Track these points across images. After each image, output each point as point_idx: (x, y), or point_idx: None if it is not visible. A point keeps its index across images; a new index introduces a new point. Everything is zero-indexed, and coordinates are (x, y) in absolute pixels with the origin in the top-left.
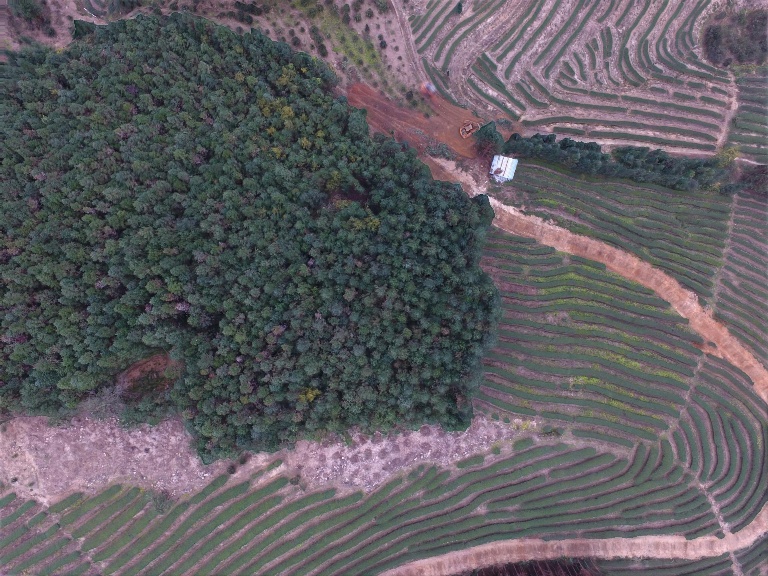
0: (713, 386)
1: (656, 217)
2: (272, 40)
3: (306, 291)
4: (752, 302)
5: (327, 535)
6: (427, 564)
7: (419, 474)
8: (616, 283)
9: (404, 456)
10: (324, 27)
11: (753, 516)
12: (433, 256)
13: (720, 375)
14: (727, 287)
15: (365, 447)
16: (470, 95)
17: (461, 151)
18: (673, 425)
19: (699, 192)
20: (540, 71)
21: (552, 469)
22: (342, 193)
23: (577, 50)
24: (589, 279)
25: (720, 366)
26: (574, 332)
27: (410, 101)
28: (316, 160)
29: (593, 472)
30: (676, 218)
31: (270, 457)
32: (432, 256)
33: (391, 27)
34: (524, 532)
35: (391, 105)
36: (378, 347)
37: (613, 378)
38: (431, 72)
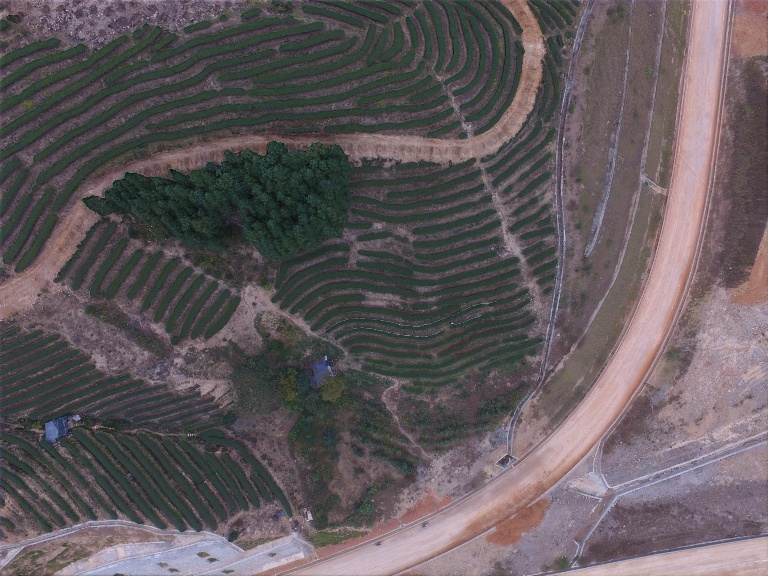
0: None
1: None
2: None
3: None
4: None
5: (56, 94)
6: (175, 159)
7: (147, 37)
8: None
9: (130, 16)
10: None
11: (495, 117)
12: None
13: None
14: None
15: (91, 4)
16: None
17: None
18: (408, 15)
19: None
20: None
21: None
22: None
23: None
24: None
25: None
26: None
27: None
28: None
29: None
30: None
31: None
32: None
33: None
34: (262, 117)
35: None
36: None
37: None
38: None
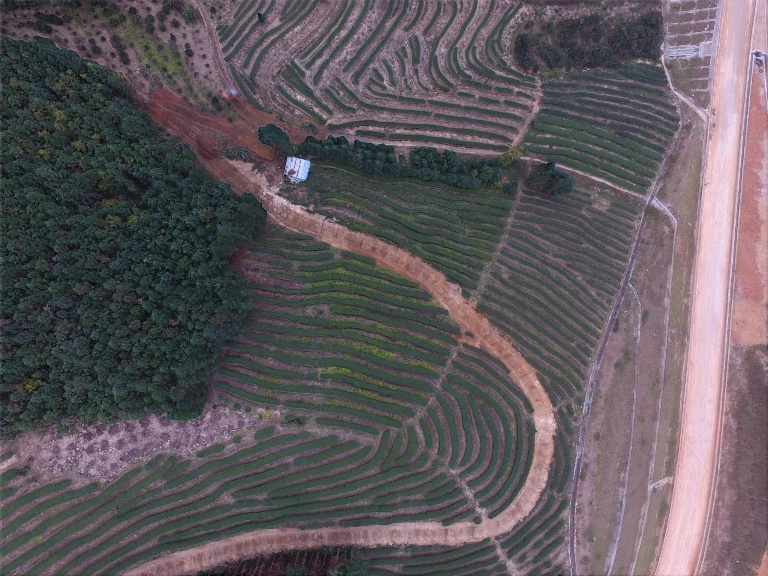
0: (467, 374)
1: (436, 214)
2: (71, 48)
3: (39, 285)
4: (520, 294)
5: (67, 527)
6: (188, 556)
7: (159, 464)
8: (381, 277)
9: (142, 446)
10: (127, 36)
11: (509, 501)
12: (175, 251)
13: (475, 364)
14: (497, 280)
15: (102, 438)
16: (278, 100)
17: (263, 154)
18: (421, 412)
19: (484, 190)
20: (350, 77)
21: (297, 457)
22: (123, 194)
23: (386, 57)
24: (356, 273)
25: (476, 355)
26: (329, 324)
27: (216, 106)
28: (83, 161)
29: (338, 460)
30: (457, 215)
31: (2, 449)
32: (174, 251)
33: (199, 36)
34: (277, 521)
35: (193, 110)
36: (99, 338)
37: (361, 367)
38: (239, 79)
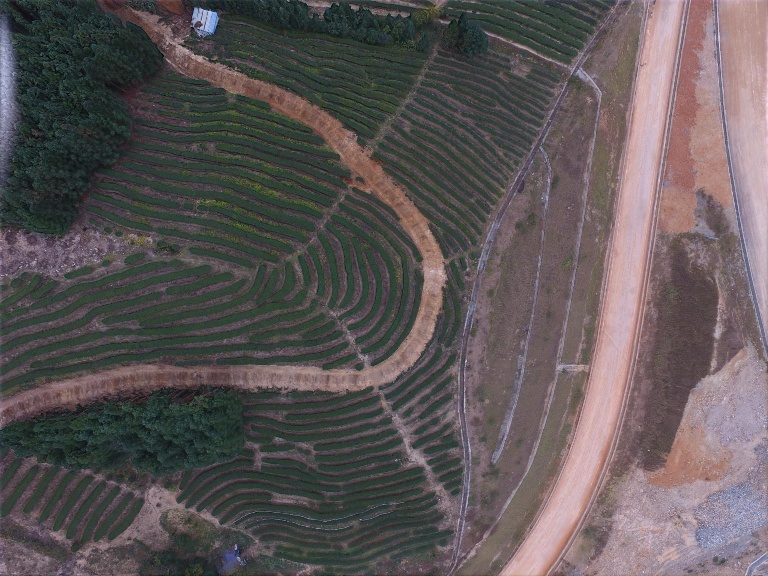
0: (354, 218)
1: (342, 68)
2: None
3: None
4: (421, 148)
5: None
6: (65, 388)
7: (26, 283)
8: (274, 120)
9: (9, 264)
10: None
11: (392, 349)
12: (47, 68)
13: (364, 209)
14: (398, 133)
15: None
16: None
17: (173, 9)
18: (302, 251)
19: (397, 49)
20: None
21: (170, 287)
22: (15, 30)
23: None
24: (249, 116)
25: (365, 200)
26: (212, 159)
27: None
28: None
29: (212, 291)
30: (365, 71)
31: None
32: (46, 68)
33: None
34: (151, 354)
35: None
36: None
37: (240, 201)
38: None
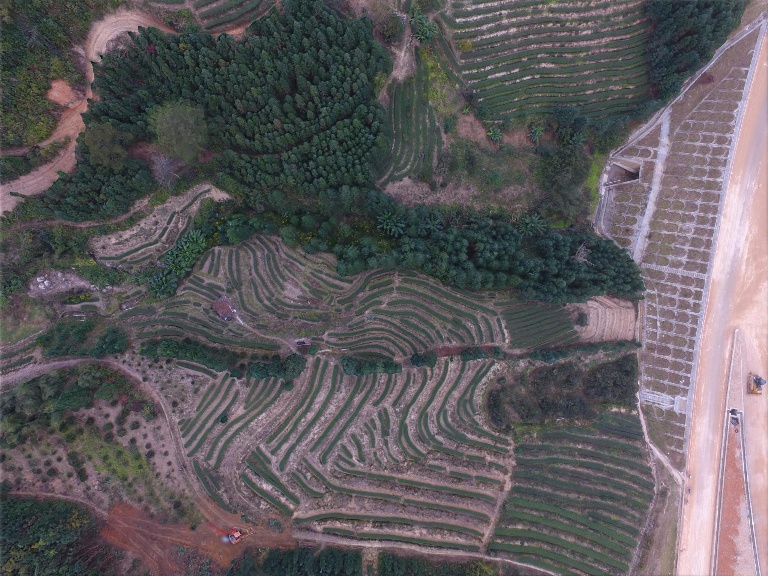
0: None
1: None
2: (26, 475)
3: None
4: None
5: None
6: None
7: None
8: None
9: None
10: (85, 449)
11: None
12: None
13: None
14: None
15: None
16: (243, 492)
17: (227, 563)
18: None
19: None
20: (317, 457)
21: None
22: None
23: (355, 431)
24: None
25: None
26: None
27: (179, 508)
28: None
29: None
30: None
31: None
32: None
33: (160, 432)
34: None
35: (154, 523)
36: None
37: None
38: (203, 473)
